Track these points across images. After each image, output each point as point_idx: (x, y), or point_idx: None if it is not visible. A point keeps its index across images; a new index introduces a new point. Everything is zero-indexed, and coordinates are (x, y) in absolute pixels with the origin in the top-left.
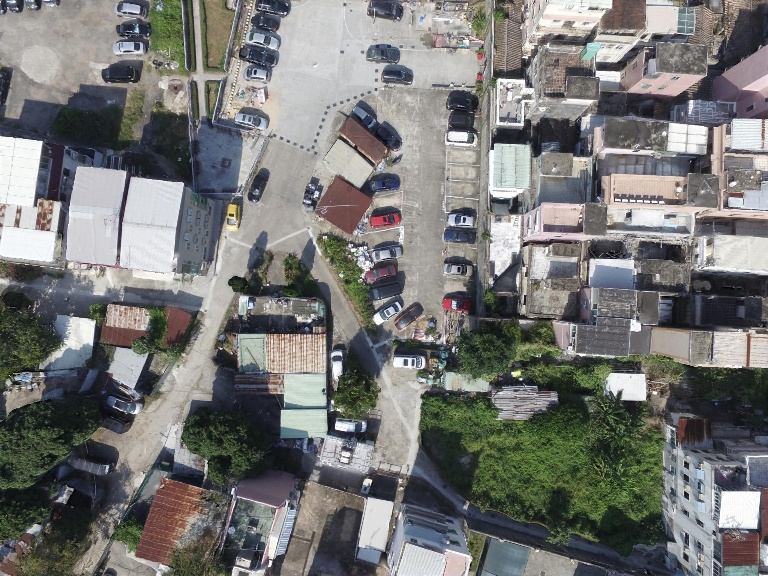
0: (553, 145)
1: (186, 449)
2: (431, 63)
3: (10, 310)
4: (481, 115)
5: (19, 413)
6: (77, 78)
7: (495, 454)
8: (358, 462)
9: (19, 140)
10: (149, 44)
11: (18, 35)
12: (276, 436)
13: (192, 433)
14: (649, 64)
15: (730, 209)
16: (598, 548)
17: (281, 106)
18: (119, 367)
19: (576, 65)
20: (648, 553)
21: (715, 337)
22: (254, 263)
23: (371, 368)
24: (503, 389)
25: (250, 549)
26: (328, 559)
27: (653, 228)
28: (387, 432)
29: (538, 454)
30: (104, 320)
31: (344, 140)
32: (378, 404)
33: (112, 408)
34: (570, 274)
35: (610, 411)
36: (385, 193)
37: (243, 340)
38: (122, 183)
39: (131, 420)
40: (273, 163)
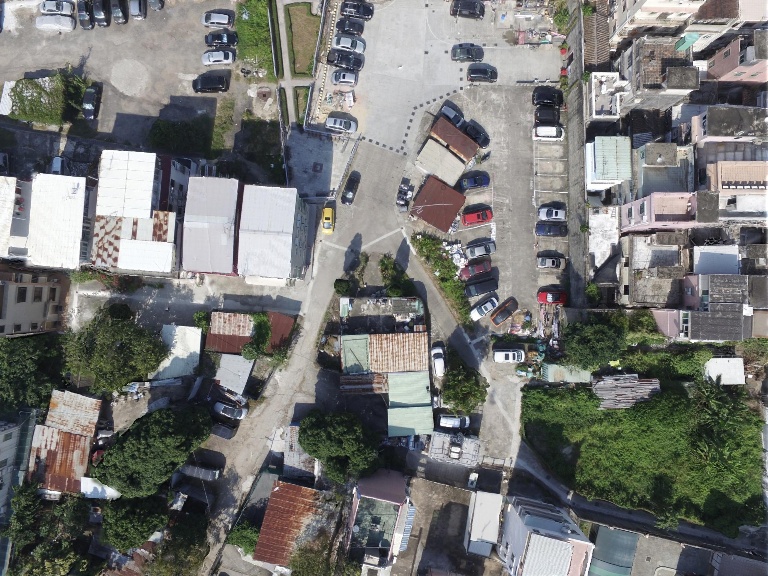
0: (645, 136)
1: (295, 451)
2: (514, 60)
3: (116, 322)
4: (567, 109)
5: (142, 423)
6: (167, 90)
7: (597, 443)
8: (466, 457)
9: (132, 153)
10: (236, 53)
11: (106, 50)
12: (380, 435)
13: (311, 435)
14: (748, 52)
15: None
16: (702, 531)
17: (369, 109)
18: (226, 373)
19: (671, 56)
20: (752, 534)
21: None
22: (350, 265)
23: (470, 364)
24: (603, 379)
25: (374, 547)
26: (436, 554)
27: (754, 213)
28: (489, 426)
29: (639, 441)
30: (209, 328)
31: None
32: None
33: (217, 414)
34: (672, 262)
35: (713, 396)
36: (475, 190)
37: (346, 341)
38: (234, 191)
39: (237, 425)
40: (364, 165)
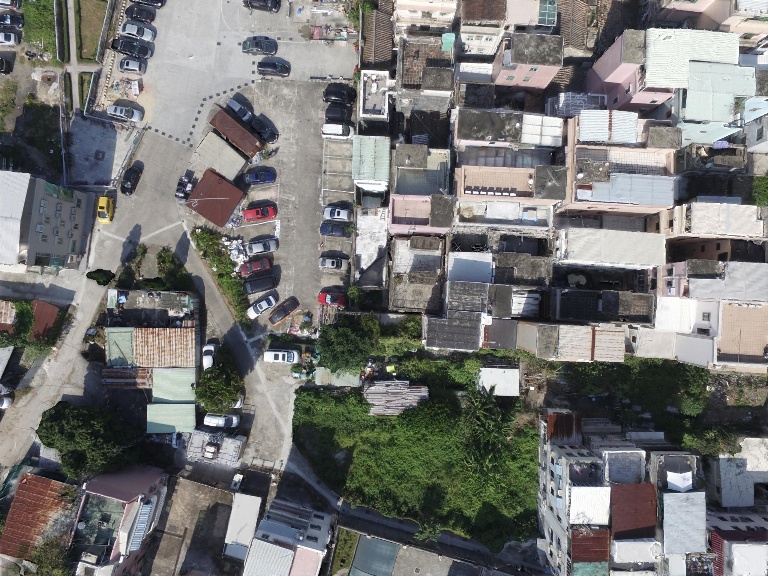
0: (422, 138)
1: None
2: (309, 55)
3: None
4: None
5: None
6: None
7: (368, 450)
8: (225, 457)
9: None
10: (22, 35)
11: None
12: None
13: (45, 427)
14: (504, 55)
15: (581, 201)
16: (473, 545)
17: (156, 98)
18: None
19: (437, 56)
20: (523, 550)
21: (560, 330)
22: (127, 256)
23: (245, 363)
24: (375, 384)
25: (102, 544)
26: (200, 555)
27: (513, 221)
28: (260, 427)
29: (413, 450)
30: None
31: None
32: (252, 399)
33: None
34: (434, 267)
35: (479, 406)
36: (261, 186)
37: (111, 334)
38: None
39: (0, 414)
40: (148, 155)
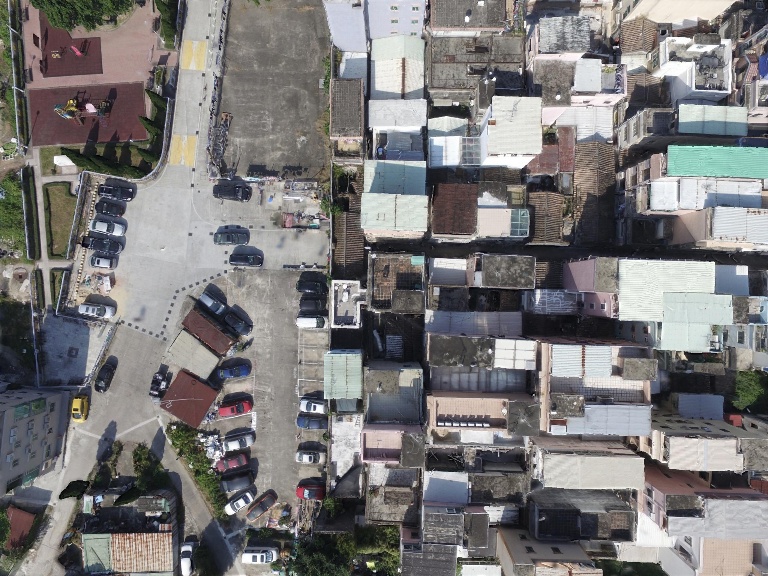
0: (397, 339)
1: None
2: (282, 243)
3: None
4: None
5: None
6: None
7: None
8: None
9: None
10: None
11: None
12: None
13: None
14: (475, 277)
15: None
16: None
17: (129, 292)
18: None
19: (407, 270)
20: None
21: (536, 573)
22: (103, 454)
23: (224, 559)
24: None
25: None
26: None
27: None
28: None
29: None
30: None
31: (189, 331)
32: None
33: None
34: (410, 479)
35: None
36: (236, 378)
37: (87, 540)
38: None
39: None
40: (121, 350)
